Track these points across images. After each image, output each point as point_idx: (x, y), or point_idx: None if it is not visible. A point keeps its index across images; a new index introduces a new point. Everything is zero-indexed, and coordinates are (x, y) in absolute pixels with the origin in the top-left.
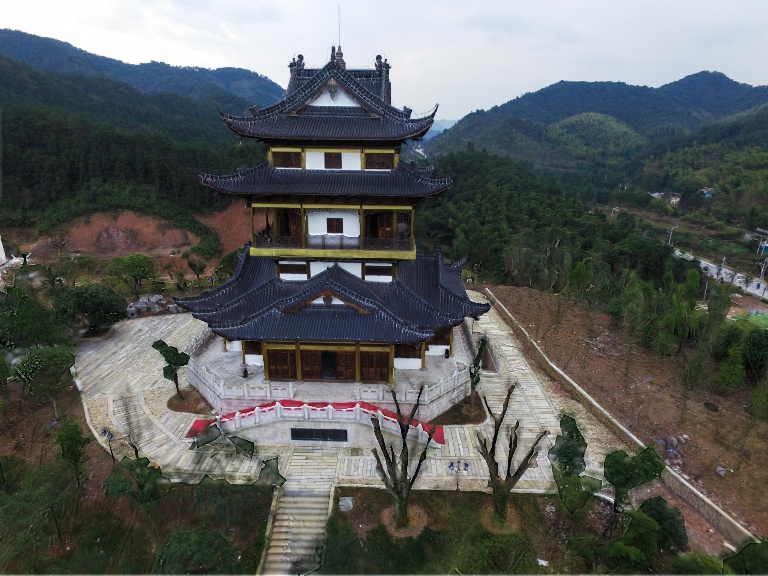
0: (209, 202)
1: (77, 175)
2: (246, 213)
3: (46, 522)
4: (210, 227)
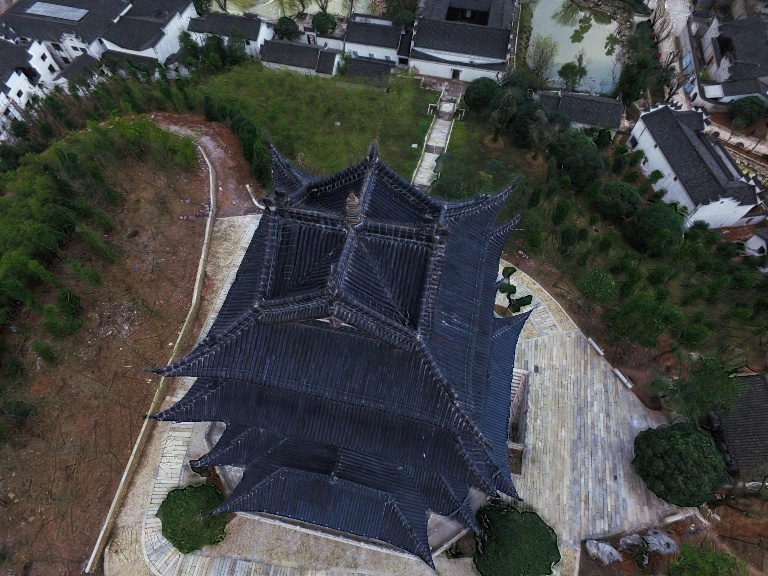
0: None
1: None
2: None
3: None
4: None
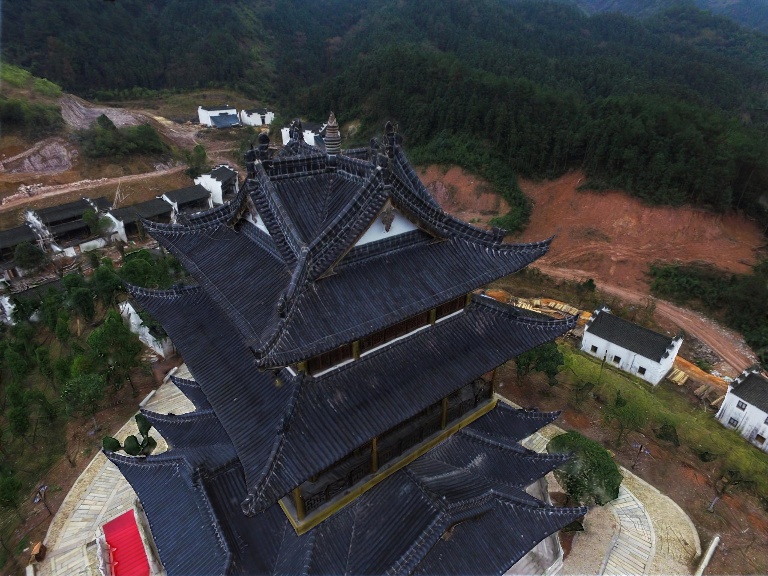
0: (543, 167)
1: (437, 123)
2: (576, 188)
3: (3, 528)
4: (529, 197)
